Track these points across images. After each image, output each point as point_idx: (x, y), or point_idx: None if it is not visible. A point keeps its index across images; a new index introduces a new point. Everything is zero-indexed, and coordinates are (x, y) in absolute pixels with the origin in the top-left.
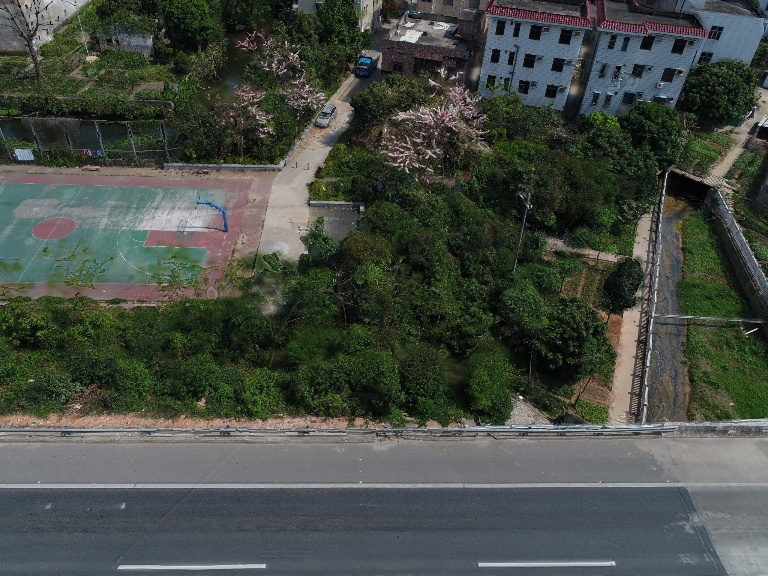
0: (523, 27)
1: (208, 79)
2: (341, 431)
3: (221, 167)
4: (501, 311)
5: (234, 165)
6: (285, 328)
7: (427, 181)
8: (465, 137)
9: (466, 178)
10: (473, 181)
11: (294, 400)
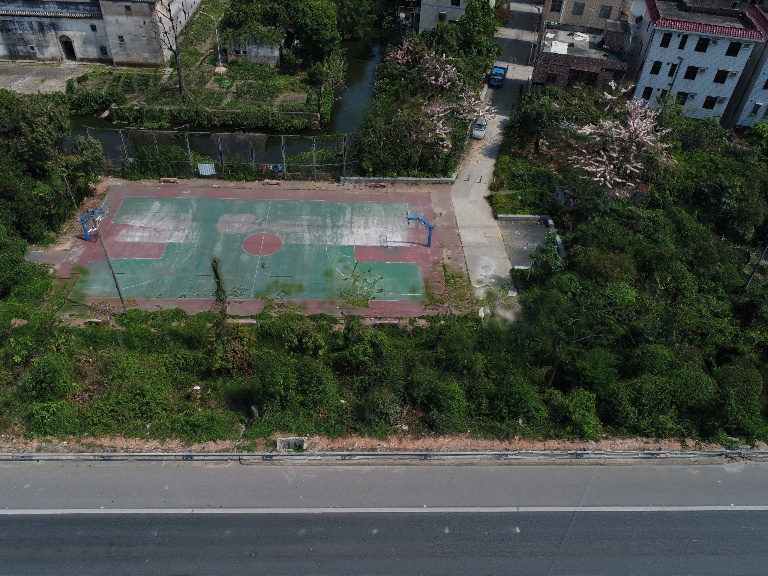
0: (690, 39)
1: (340, 90)
2: (692, 453)
3: (396, 180)
4: (761, 328)
5: (409, 178)
6: (572, 347)
7: (627, 195)
8: (658, 151)
9: (660, 192)
10: (667, 195)
11: (610, 420)
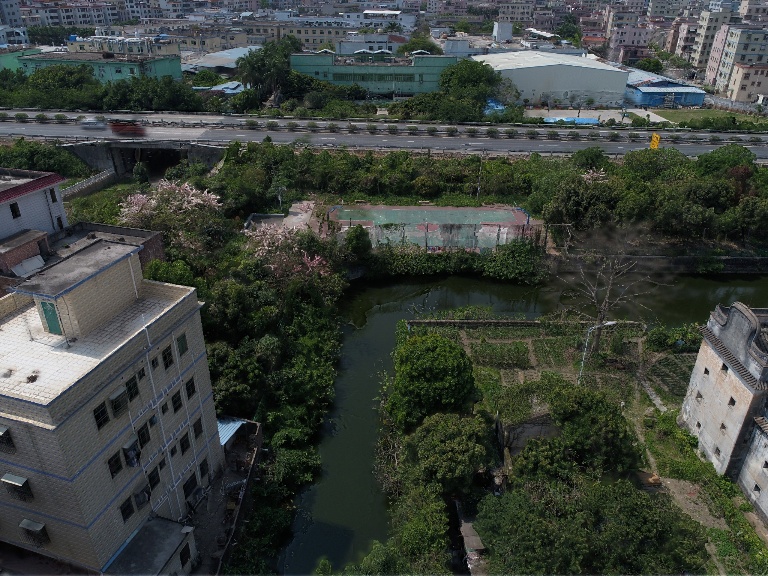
0: None
1: None
2: None
3: None
4: None
5: None
6: None
7: None
8: None
9: None
10: None
11: None
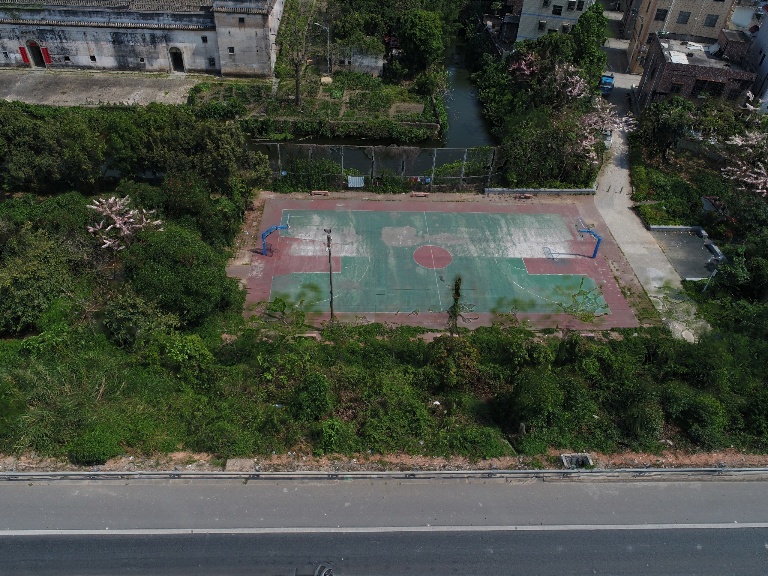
0: None
1: (448, 99)
2: None
3: (539, 191)
4: None
5: (551, 189)
6: None
7: None
8: None
9: None
10: None
11: None
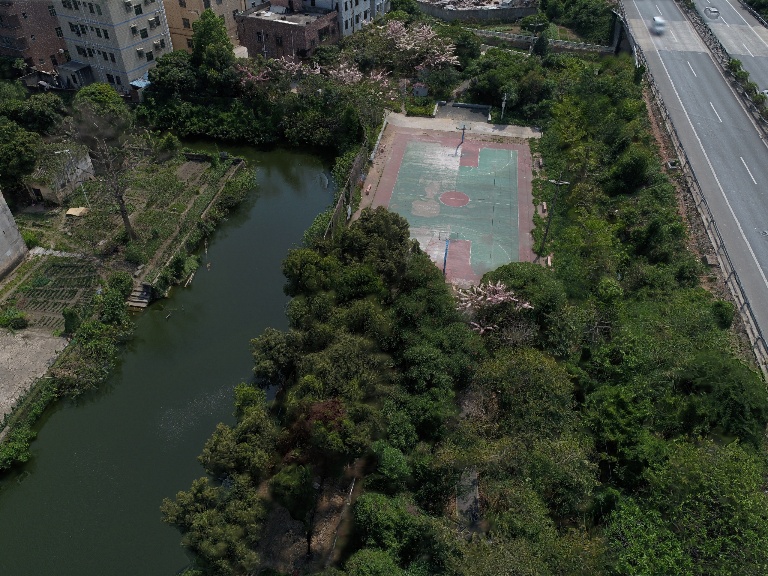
0: None
1: None
2: None
3: None
4: None
5: (380, 135)
6: None
7: None
8: None
9: None
10: None
11: None
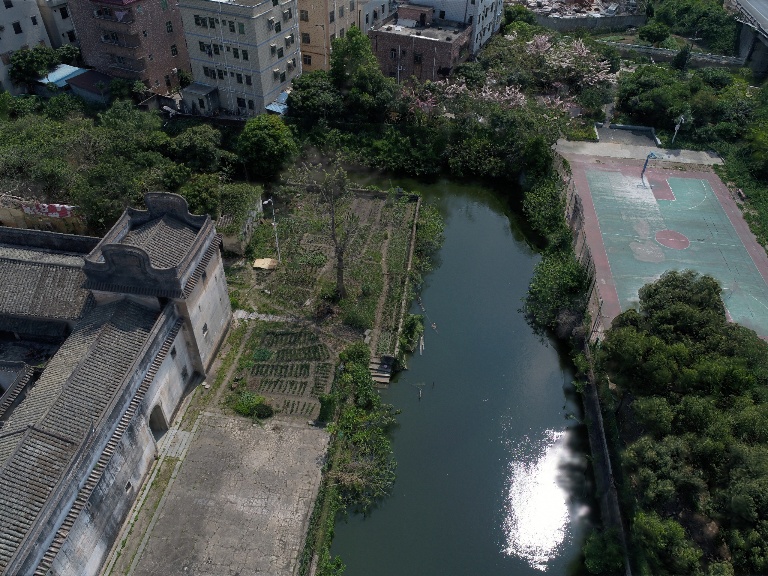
0: None
1: None
2: None
3: None
4: (725, 83)
5: None
6: None
7: None
8: None
9: None
10: None
11: None
